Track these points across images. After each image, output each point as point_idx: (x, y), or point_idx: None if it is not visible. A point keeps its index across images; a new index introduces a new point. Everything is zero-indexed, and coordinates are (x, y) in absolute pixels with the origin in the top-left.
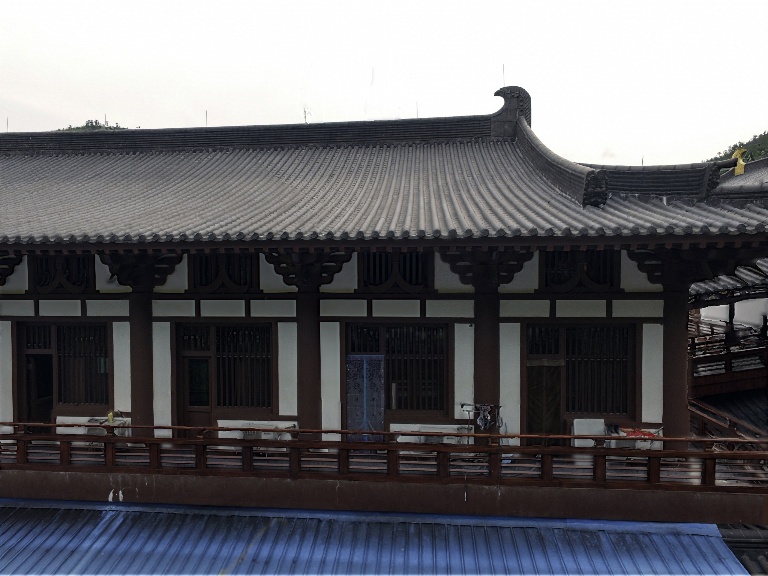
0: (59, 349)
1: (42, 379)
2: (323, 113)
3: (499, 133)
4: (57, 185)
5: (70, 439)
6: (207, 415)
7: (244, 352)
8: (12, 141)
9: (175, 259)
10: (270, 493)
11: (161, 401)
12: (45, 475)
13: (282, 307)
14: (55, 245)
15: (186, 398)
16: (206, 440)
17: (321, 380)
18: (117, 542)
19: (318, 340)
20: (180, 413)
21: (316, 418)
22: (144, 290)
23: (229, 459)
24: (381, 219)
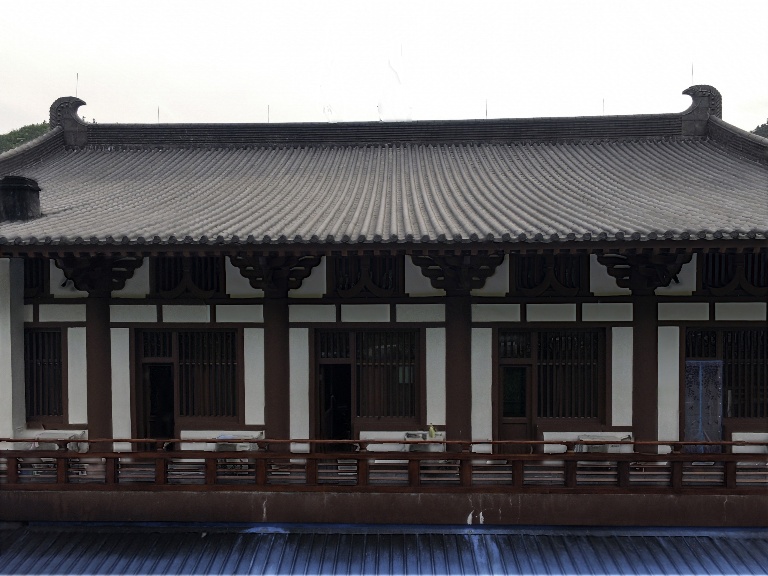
0: (358, 358)
1: (328, 391)
2: (344, 111)
3: (690, 132)
4: (261, 180)
5: (422, 457)
6: (524, 427)
7: (567, 359)
8: (165, 133)
9: (497, 260)
10: (651, 510)
11: (481, 413)
12: (394, 497)
13: (617, 311)
14: (453, 245)
15: (501, 409)
16: (579, 455)
17: (658, 388)
18: (517, 570)
19: (656, 346)
20: (498, 425)
21: (653, 428)
22: (465, 293)
23: (602, 475)
24: (760, 218)
